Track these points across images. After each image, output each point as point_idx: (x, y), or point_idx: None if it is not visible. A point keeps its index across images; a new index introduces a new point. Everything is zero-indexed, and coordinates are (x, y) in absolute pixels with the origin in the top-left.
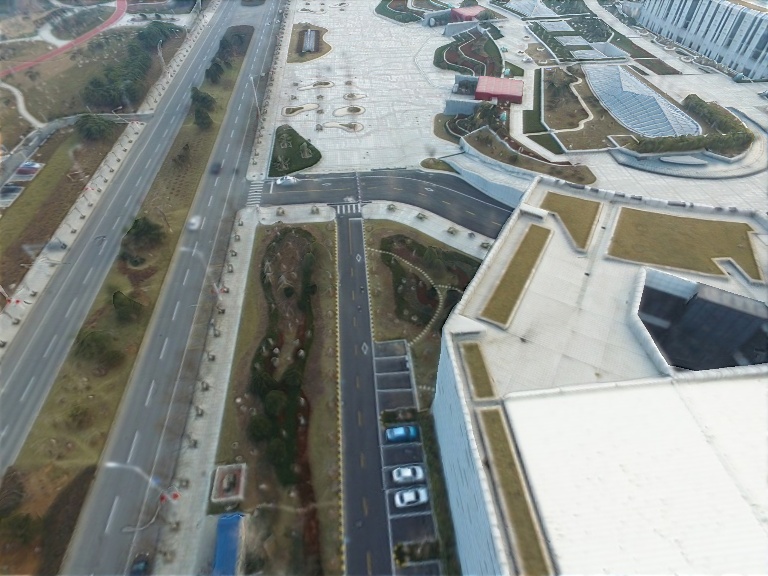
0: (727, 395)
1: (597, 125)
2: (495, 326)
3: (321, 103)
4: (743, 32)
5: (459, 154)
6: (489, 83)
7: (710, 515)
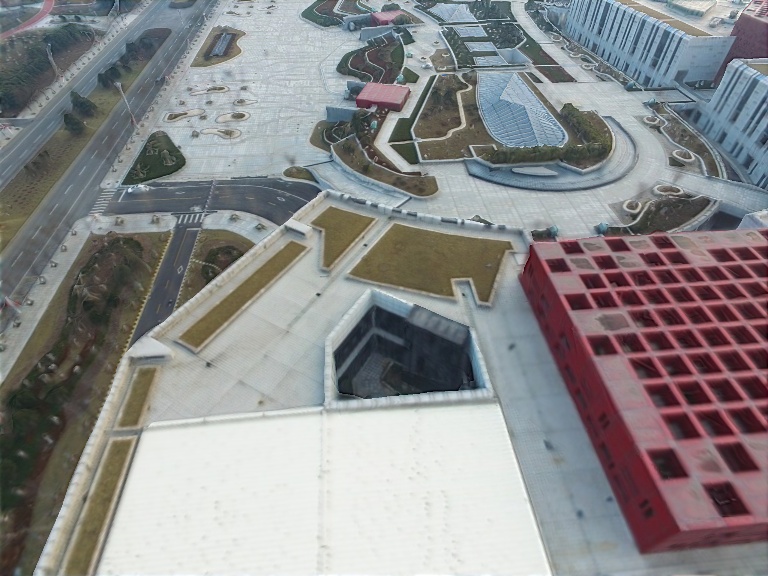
0: (372, 426)
1: (465, 134)
2: (187, 350)
3: (208, 109)
4: (644, 40)
5: (327, 162)
6: (373, 90)
7: (272, 557)
